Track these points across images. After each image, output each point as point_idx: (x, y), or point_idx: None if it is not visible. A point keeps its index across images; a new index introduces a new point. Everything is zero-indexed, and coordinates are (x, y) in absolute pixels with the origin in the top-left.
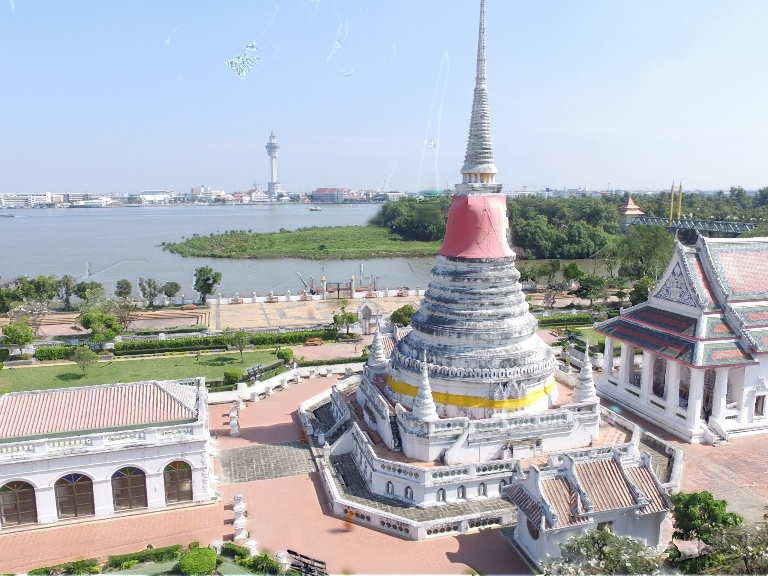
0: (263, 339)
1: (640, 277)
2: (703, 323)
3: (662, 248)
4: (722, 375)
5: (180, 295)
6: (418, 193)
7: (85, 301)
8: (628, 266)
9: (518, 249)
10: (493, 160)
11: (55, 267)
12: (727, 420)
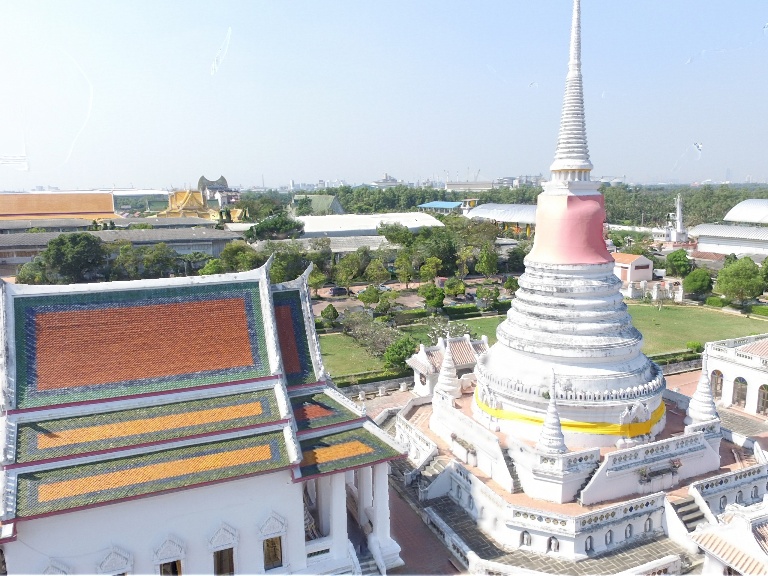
0: None
1: None
2: None
3: None
4: None
5: None
6: None
7: None
8: None
9: None
10: (555, 156)
11: None
12: None
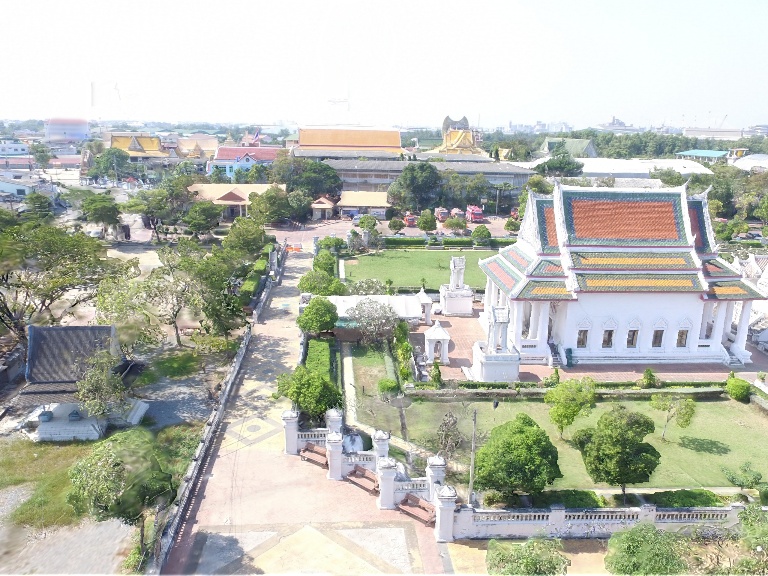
0: None
1: None
2: None
3: None
4: None
5: None
6: None
7: None
8: None
9: None
10: None
11: None
12: None
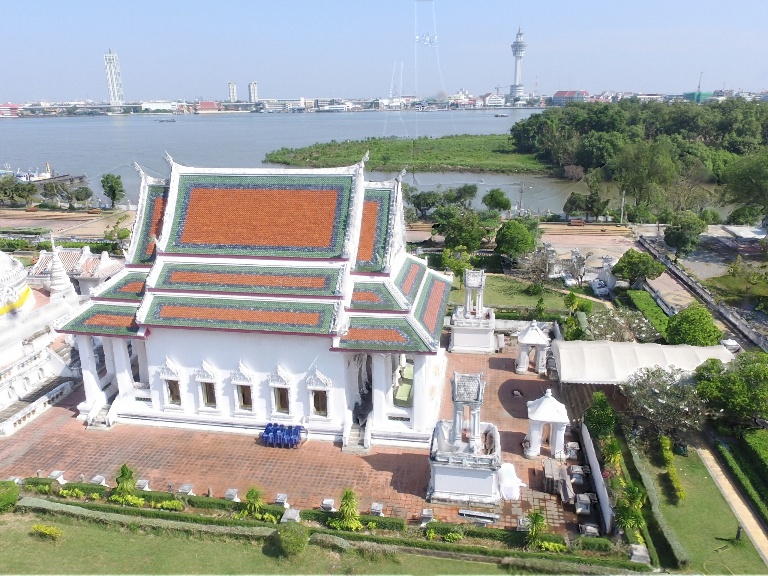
0: (46, 247)
1: (596, 212)
2: (114, 278)
3: (664, 175)
4: (113, 345)
5: (97, 199)
6: (419, 99)
7: (25, 200)
8: (576, 197)
9: (574, 168)
10: None
11: (110, 168)
12: (137, 402)
